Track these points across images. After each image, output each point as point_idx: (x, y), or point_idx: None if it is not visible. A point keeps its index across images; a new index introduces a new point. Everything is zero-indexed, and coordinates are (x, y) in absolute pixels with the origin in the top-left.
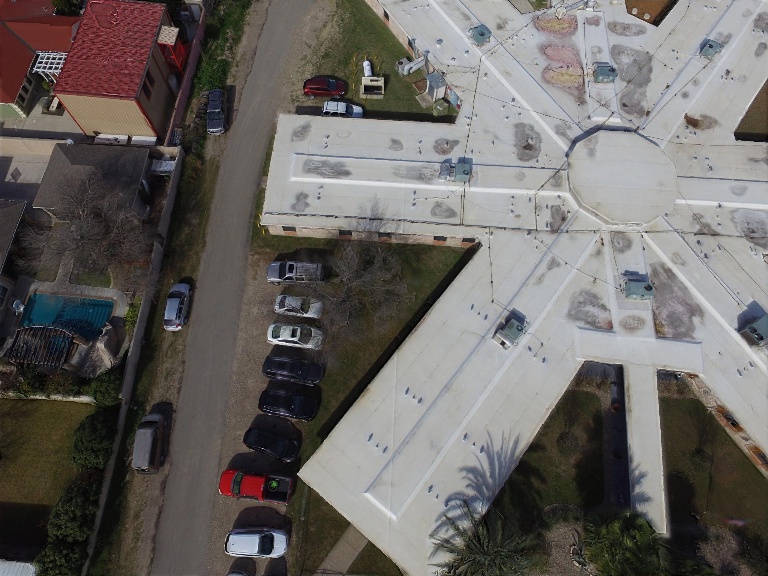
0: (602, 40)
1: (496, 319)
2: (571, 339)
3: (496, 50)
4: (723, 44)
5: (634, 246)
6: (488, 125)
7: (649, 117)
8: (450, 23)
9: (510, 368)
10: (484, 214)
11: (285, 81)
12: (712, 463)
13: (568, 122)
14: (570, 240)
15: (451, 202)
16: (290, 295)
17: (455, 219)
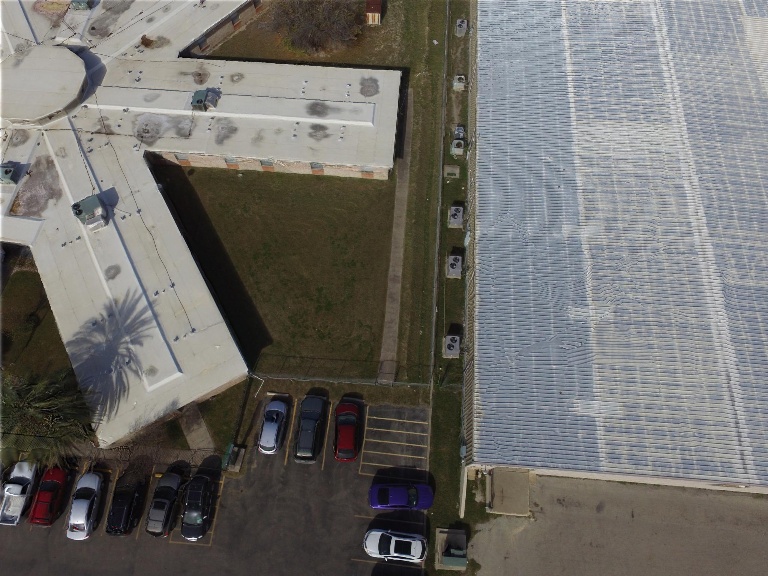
0: None
1: None
2: None
3: None
4: None
5: (29, 141)
6: None
7: (106, 38)
8: None
9: None
10: None
11: None
12: (37, 325)
13: (31, 41)
14: None
15: None
16: None
17: None
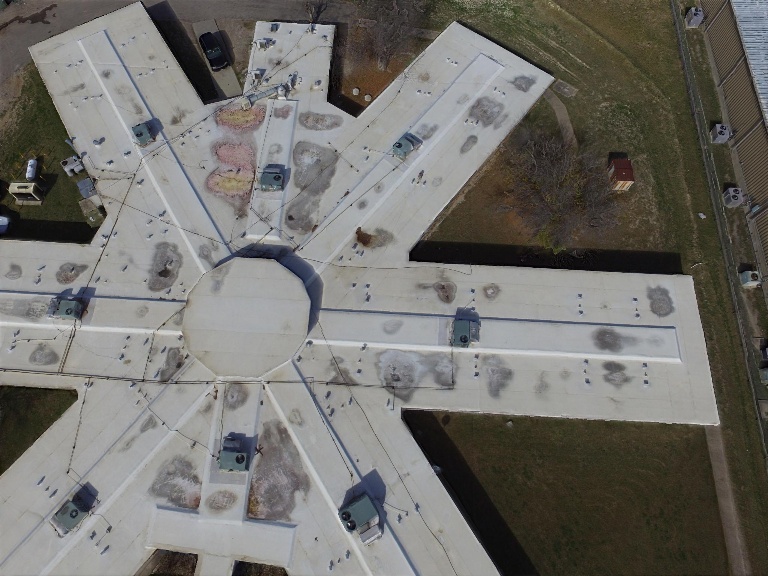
0: (285, 137)
1: (64, 496)
2: (146, 521)
3: (161, 151)
4: (424, 139)
5: (249, 401)
6: (126, 246)
7: (313, 234)
8: (119, 117)
9: (64, 560)
10: (90, 359)
11: None
12: None
13: (216, 241)
14: (176, 394)
15: (56, 344)
16: None
17: (54, 366)
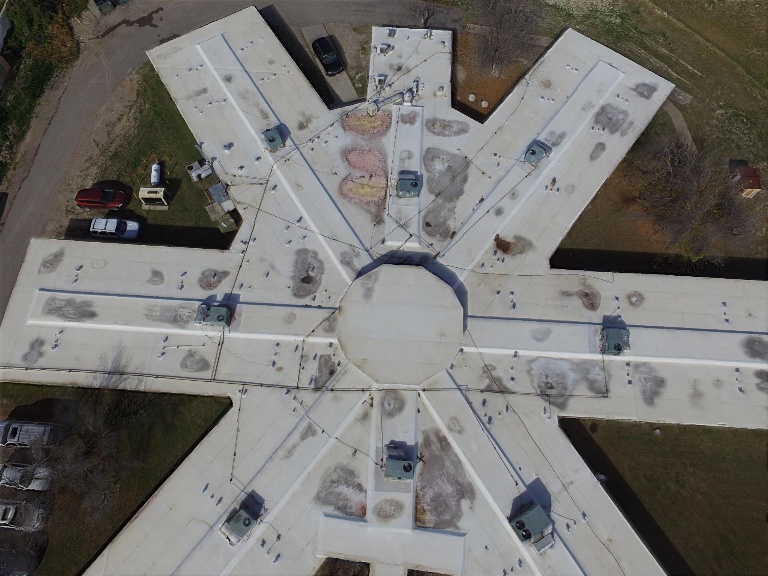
0: (415, 143)
1: (230, 504)
2: (314, 530)
3: (291, 156)
4: (554, 146)
5: (406, 408)
6: (266, 252)
7: (452, 240)
8: (245, 122)
9: (236, 568)
10: (241, 366)
11: (62, 188)
12: None
13: (357, 248)
14: (333, 401)
15: (206, 351)
16: (17, 461)
17: (206, 373)
